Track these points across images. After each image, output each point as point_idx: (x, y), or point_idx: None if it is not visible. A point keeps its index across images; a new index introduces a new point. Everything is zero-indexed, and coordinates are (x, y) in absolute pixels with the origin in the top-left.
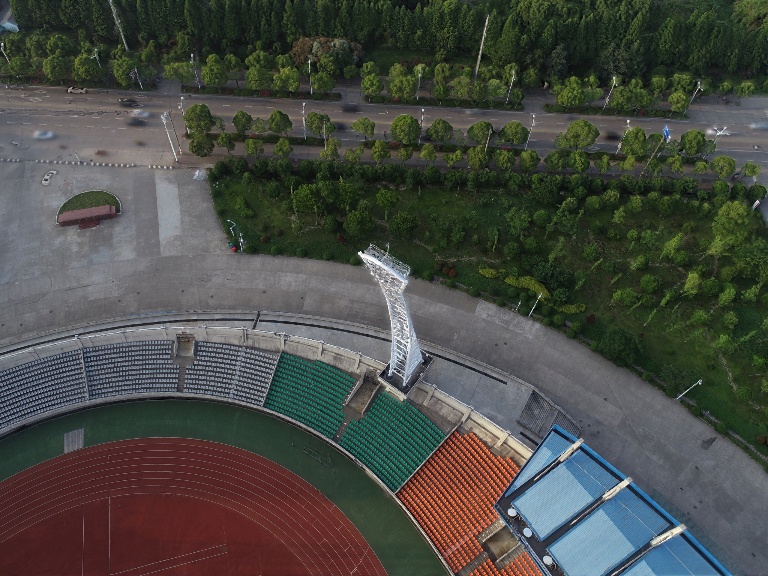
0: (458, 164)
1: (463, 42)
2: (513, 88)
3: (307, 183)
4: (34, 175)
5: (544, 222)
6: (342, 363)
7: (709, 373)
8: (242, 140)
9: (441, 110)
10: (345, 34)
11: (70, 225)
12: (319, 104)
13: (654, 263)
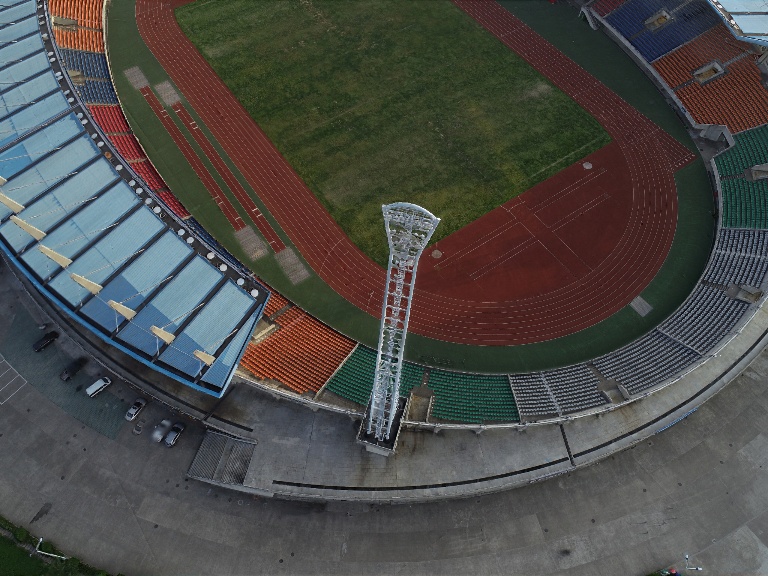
0: None
1: None
2: None
3: None
4: None
5: None
6: None
7: None
8: None
9: None
10: None
11: None
12: None
13: None
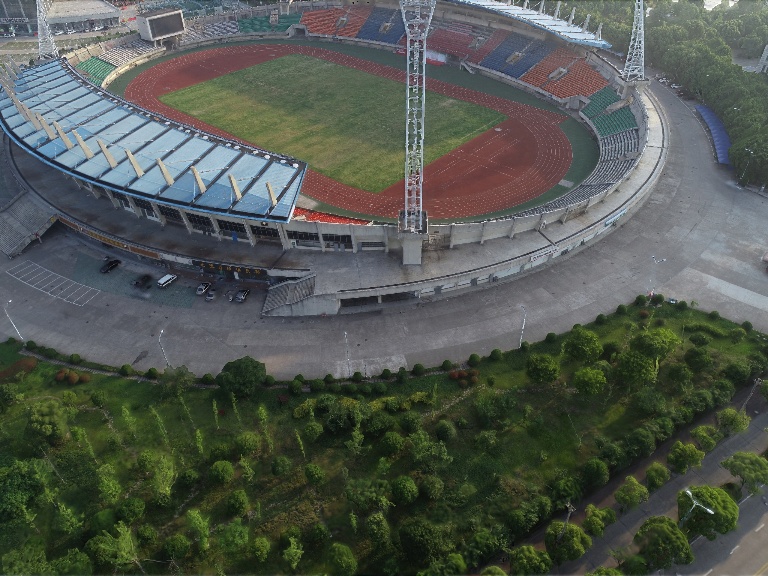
0: None
1: None
2: None
3: (700, 388)
4: None
5: None
6: None
7: (136, 416)
8: None
9: None
10: None
11: None
12: None
13: None
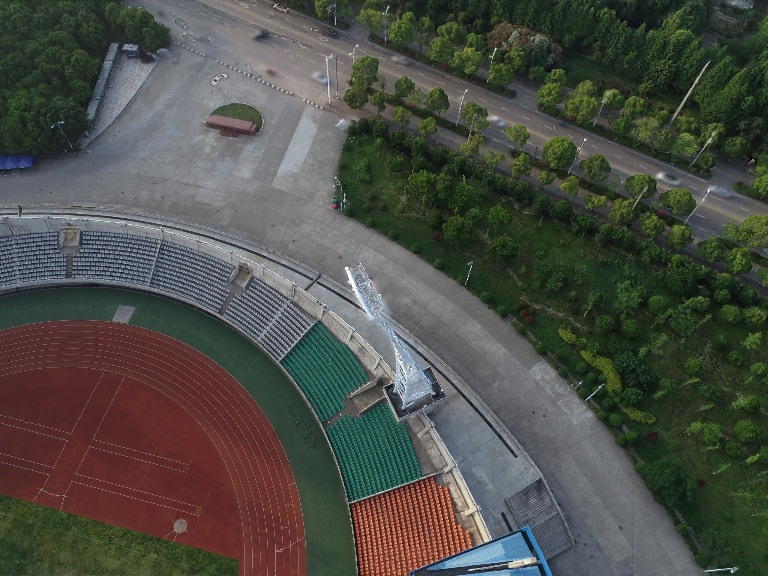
0: (600, 210)
1: (678, 81)
2: (706, 151)
3: (435, 170)
4: (209, 73)
5: (658, 310)
6: (364, 357)
7: (763, 564)
8: (397, 105)
9: (614, 146)
10: (552, 32)
11: (214, 128)
12: (490, 95)
13: (767, 411)
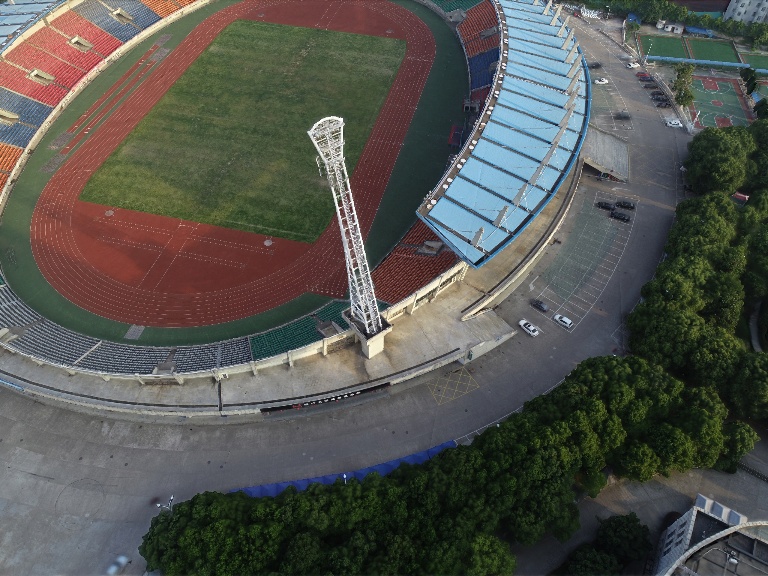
0: None
1: None
2: None
3: None
4: None
5: None
6: None
7: None
8: None
9: None
10: None
11: None
12: None
13: None
